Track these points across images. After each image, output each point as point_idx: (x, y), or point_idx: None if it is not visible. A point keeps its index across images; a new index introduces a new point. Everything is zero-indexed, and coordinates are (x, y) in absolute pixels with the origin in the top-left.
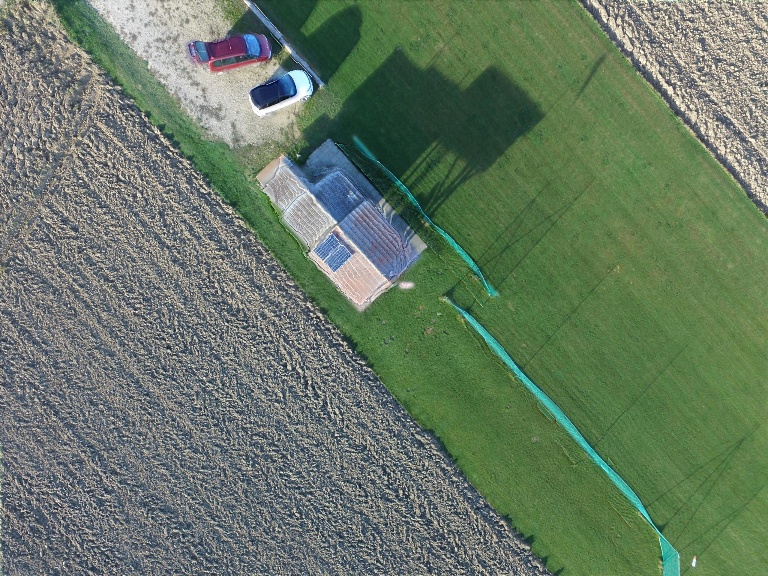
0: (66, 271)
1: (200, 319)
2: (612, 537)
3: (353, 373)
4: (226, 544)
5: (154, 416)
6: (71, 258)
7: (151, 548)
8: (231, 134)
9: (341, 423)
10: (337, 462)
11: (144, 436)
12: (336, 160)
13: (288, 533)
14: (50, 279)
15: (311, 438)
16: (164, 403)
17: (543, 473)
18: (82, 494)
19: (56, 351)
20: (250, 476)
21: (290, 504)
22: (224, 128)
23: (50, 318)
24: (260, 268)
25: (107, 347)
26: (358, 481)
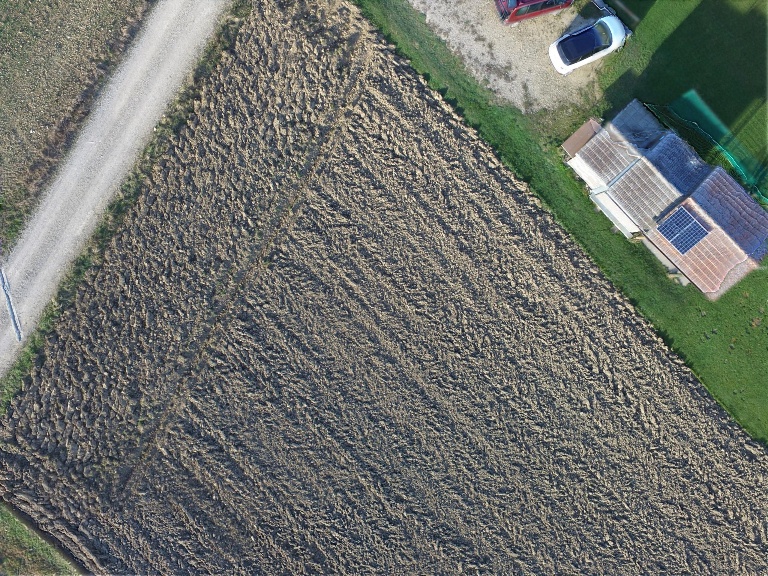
0: (338, 265)
1: (492, 316)
2: None
3: (671, 374)
4: None
5: (443, 432)
6: (343, 249)
7: None
8: (523, 97)
9: (657, 434)
10: (654, 480)
11: (431, 456)
12: (646, 123)
13: (600, 565)
14: (319, 275)
15: (623, 452)
16: (453, 416)
17: None
18: (363, 526)
19: (328, 359)
20: (554, 499)
21: (601, 530)
22: (515, 90)
23: (321, 321)
24: (559, 254)
25: (386, 353)
26: (679, 501)
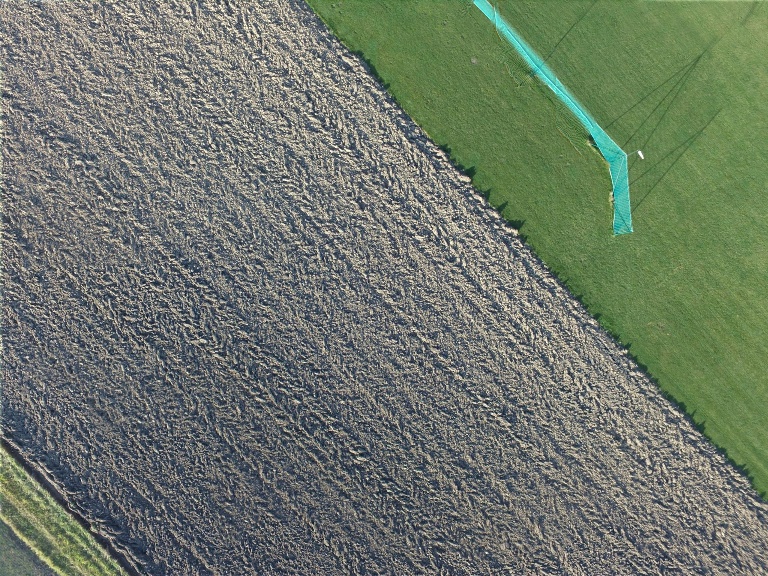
0: None
1: None
2: (561, 166)
3: None
4: (135, 179)
5: (47, 31)
6: None
7: (51, 181)
8: None
9: (259, 43)
10: (256, 88)
11: (37, 54)
12: None
13: (204, 167)
14: None
15: (226, 60)
16: (58, 17)
17: (484, 96)
18: None
19: None
20: (159, 103)
21: (205, 134)
22: None
23: None
24: None
25: None
26: (280, 109)
